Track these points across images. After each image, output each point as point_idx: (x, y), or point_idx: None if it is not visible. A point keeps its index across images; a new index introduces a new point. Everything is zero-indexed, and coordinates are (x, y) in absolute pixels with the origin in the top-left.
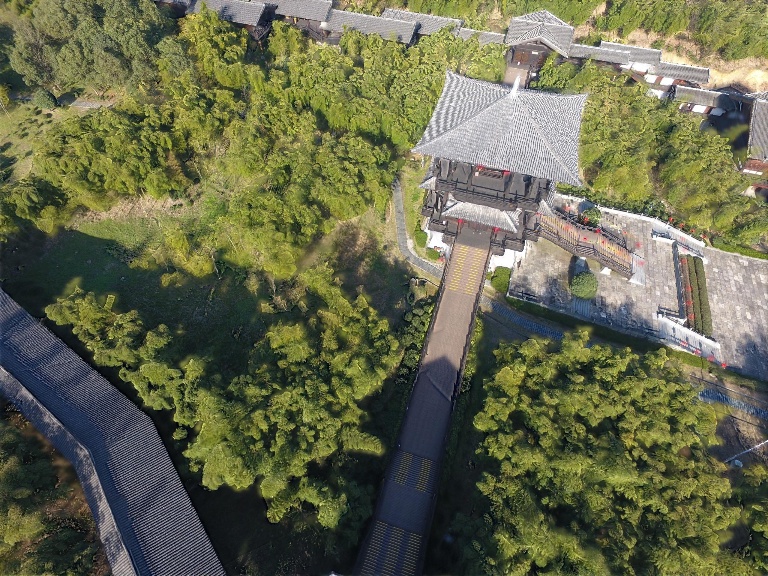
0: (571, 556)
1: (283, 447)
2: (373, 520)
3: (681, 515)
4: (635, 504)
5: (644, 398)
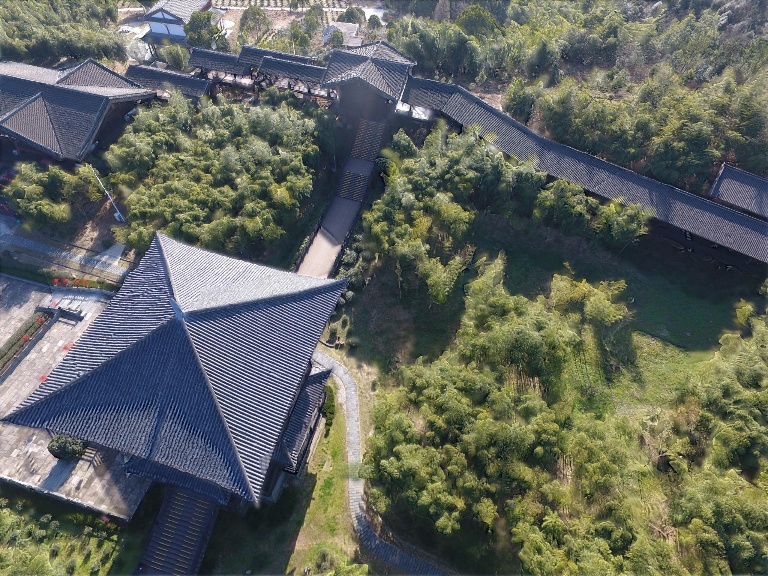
0: (278, 117)
1: None
2: None
3: (200, 147)
4: None
5: None
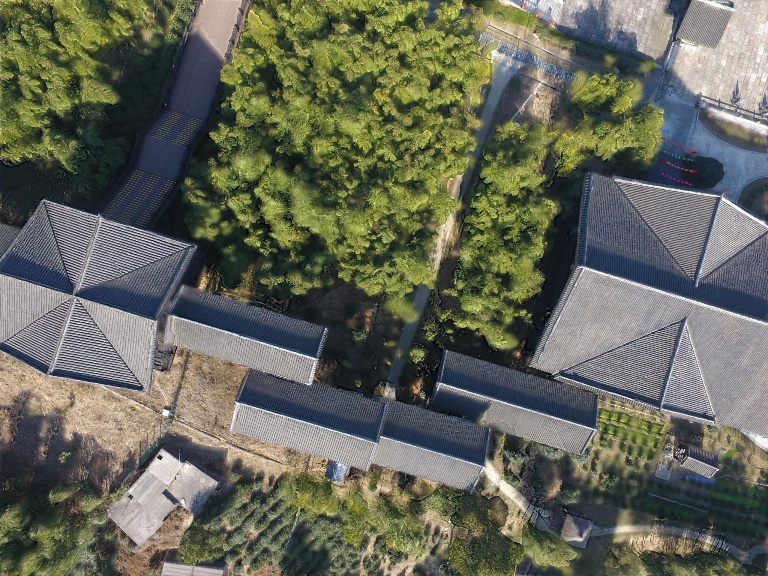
0: (276, 190)
1: (5, 96)
2: (129, 169)
3: (406, 162)
4: (364, 153)
5: (414, 52)
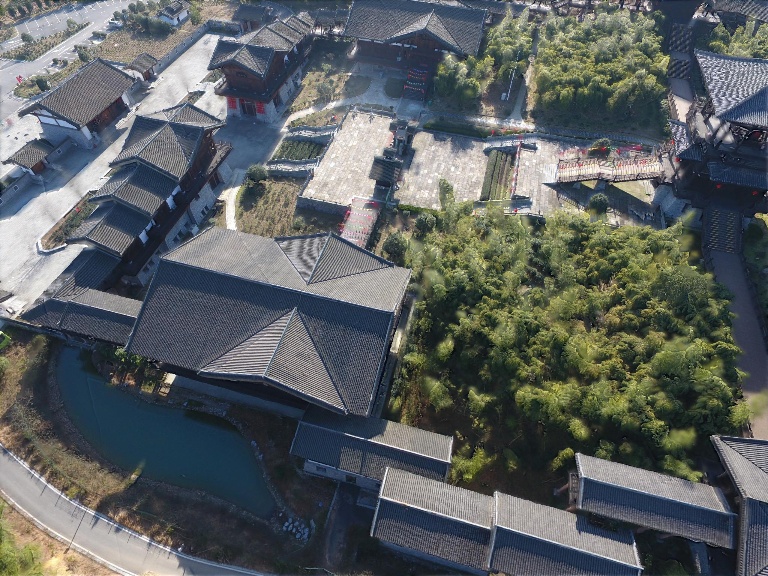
0: None
1: None
2: None
3: None
4: None
5: None
